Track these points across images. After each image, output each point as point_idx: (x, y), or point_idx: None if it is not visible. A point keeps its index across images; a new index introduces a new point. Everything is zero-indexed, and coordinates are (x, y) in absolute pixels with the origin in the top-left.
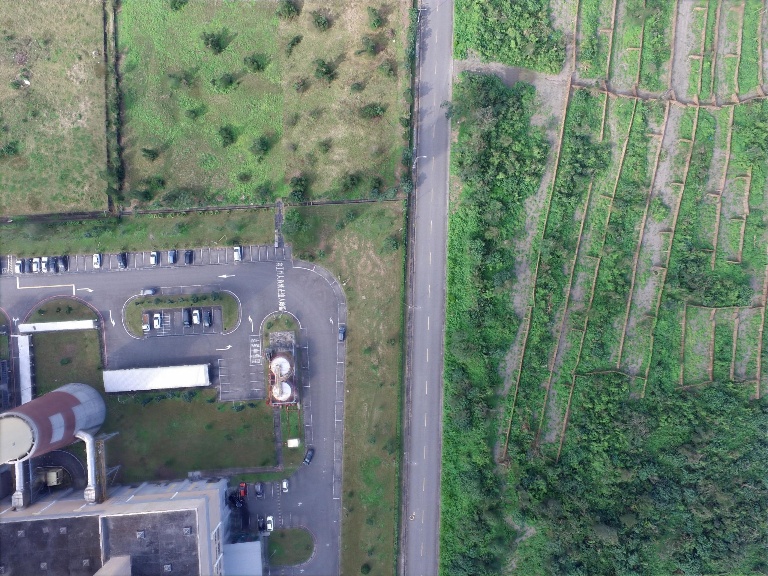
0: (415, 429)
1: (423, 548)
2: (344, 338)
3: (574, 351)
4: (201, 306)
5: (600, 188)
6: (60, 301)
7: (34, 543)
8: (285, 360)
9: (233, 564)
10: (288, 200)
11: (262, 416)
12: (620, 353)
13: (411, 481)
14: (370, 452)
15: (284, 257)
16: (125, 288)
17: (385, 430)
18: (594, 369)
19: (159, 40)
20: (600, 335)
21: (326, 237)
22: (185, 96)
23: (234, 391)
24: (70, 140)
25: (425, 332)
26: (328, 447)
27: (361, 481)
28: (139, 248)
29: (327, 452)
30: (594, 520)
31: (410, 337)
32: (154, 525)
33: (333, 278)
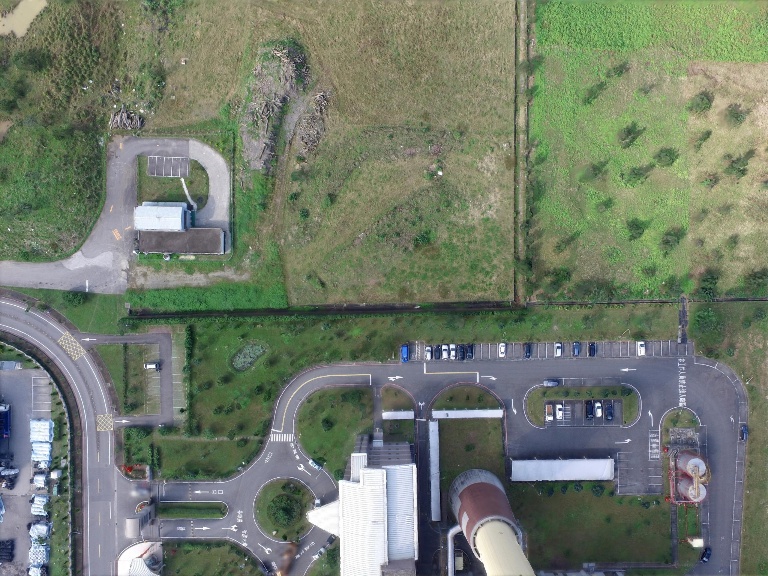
0: None
1: None
2: None
3: None
4: (602, 399)
5: None
6: (465, 388)
7: None
8: (701, 461)
9: None
10: None
11: (660, 512)
12: None
13: None
14: None
15: (686, 353)
16: (528, 377)
17: None
18: None
19: (569, 133)
20: None
21: (730, 334)
22: (592, 189)
23: (632, 485)
24: (480, 231)
25: None
26: (725, 547)
27: None
28: (543, 339)
29: (724, 552)
30: None
31: None
32: None
33: (735, 376)
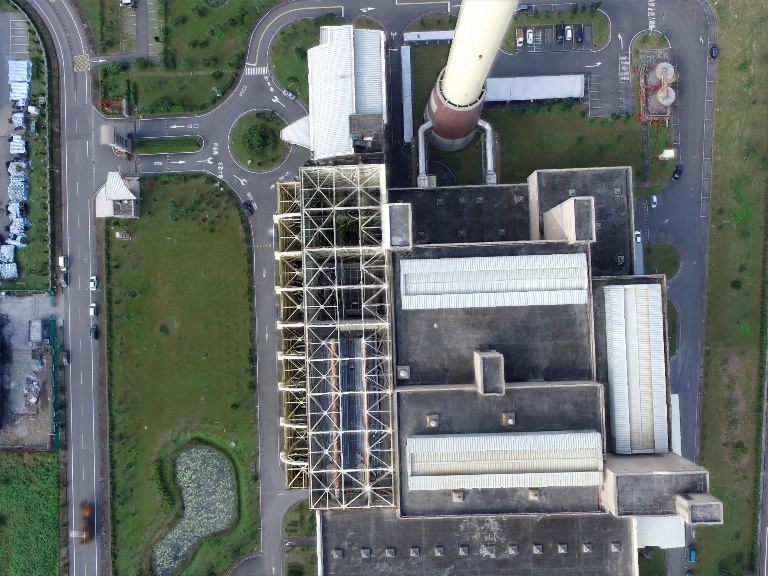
0: None
1: None
2: None
3: None
4: (572, 23)
5: None
6: (436, 17)
7: (451, 212)
8: (670, 65)
9: None
10: None
11: (631, 132)
12: None
13: None
14: (741, 170)
15: None
16: None
17: (756, 149)
18: None
19: None
20: None
21: None
22: None
23: (603, 107)
24: None
25: None
26: (696, 165)
27: (731, 198)
28: None
29: (695, 170)
30: None
31: None
32: (585, 184)
33: None
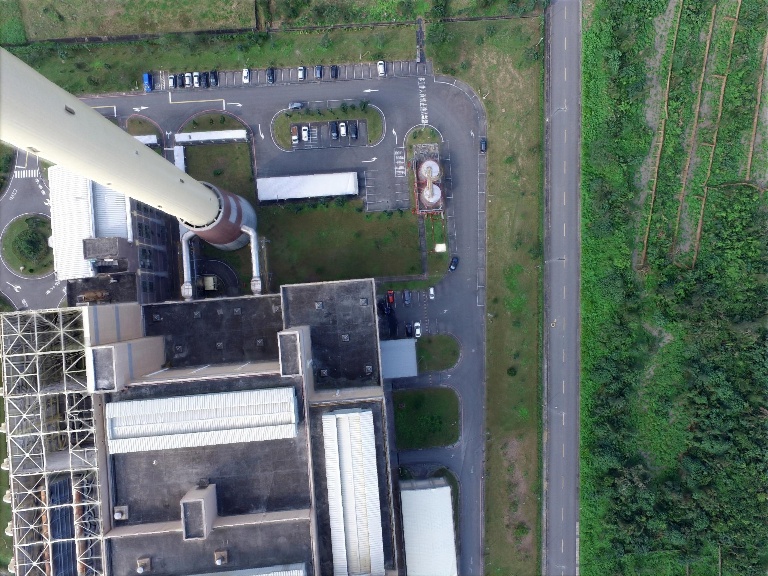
0: (554, 239)
1: (565, 354)
2: (485, 150)
3: (704, 165)
4: (347, 119)
5: (723, 11)
6: (211, 115)
7: (209, 324)
8: (435, 163)
9: (389, 360)
10: (428, 17)
11: (408, 225)
12: (749, 166)
13: (552, 289)
14: (513, 259)
15: (426, 72)
16: (273, 102)
17: (527, 238)
18: (724, 182)
19: None
20: (730, 148)
21: (466, 52)
22: None
23: (380, 202)
24: None
25: (562, 145)
26: (472, 256)
27: (505, 287)
28: (286, 63)
29: (471, 261)
30: (732, 322)
31: (548, 150)
32: (331, 297)
33: (473, 92)
